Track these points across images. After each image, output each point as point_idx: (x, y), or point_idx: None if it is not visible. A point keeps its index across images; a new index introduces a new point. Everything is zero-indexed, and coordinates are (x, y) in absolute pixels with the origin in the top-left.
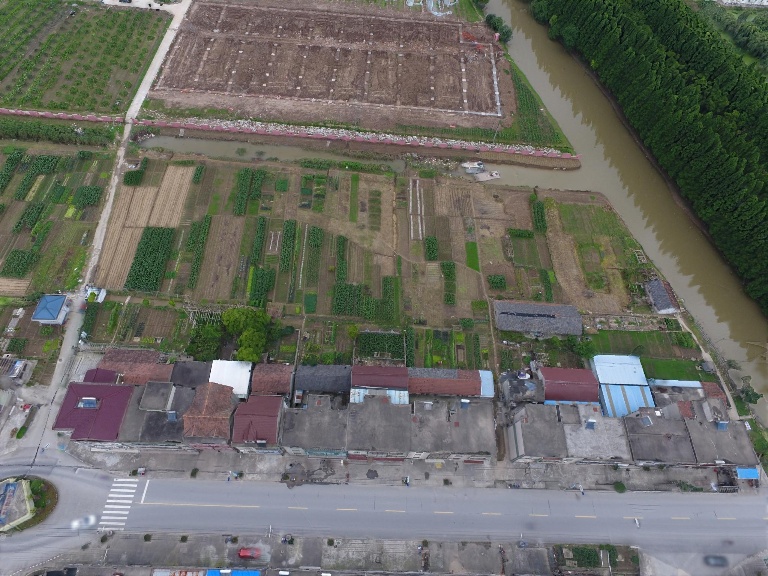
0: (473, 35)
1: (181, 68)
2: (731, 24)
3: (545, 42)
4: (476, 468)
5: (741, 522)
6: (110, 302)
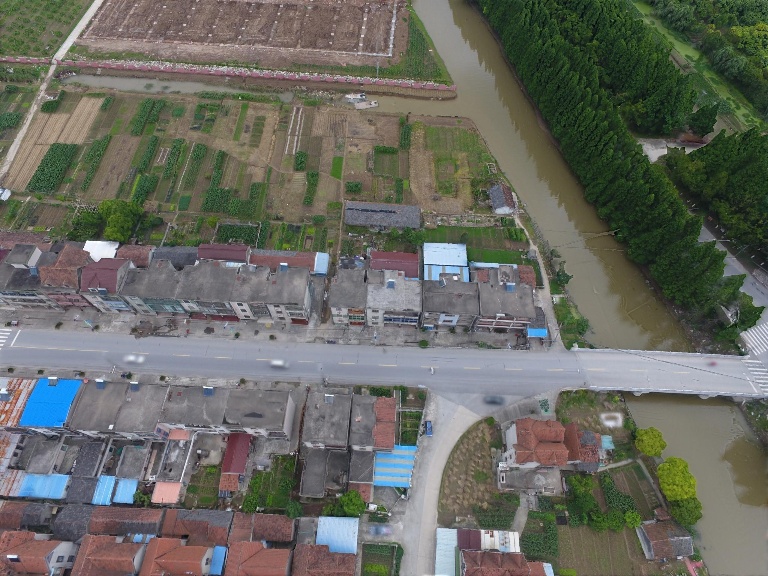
0: None
1: (109, 20)
2: None
3: None
4: (301, 328)
5: (526, 372)
6: (12, 200)
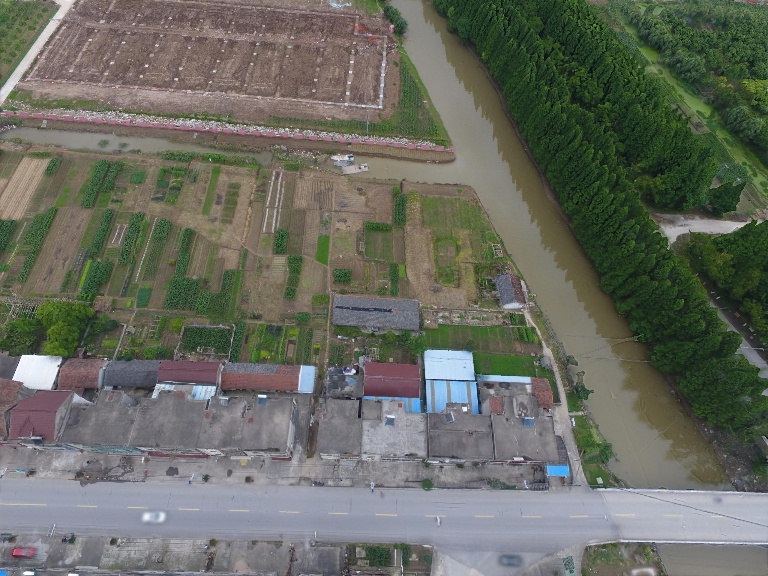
0: (368, 27)
1: (57, 59)
2: (636, 17)
3: (445, 34)
4: (283, 465)
5: (546, 520)
6: None
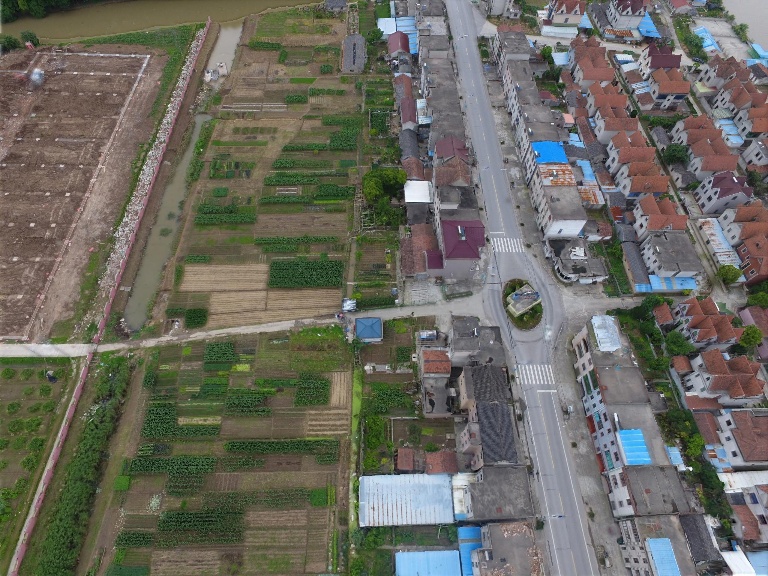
0: (19, 62)
1: None
2: None
3: (41, 25)
4: None
5: (458, 5)
6: None
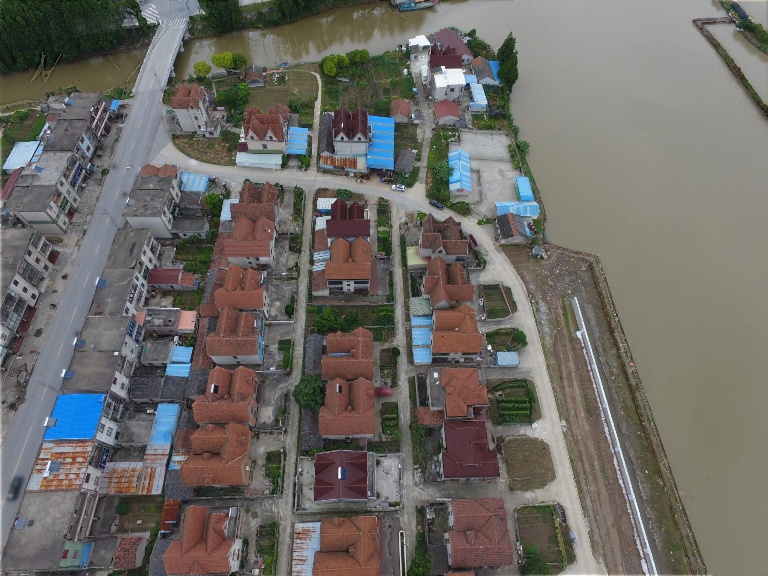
0: None
1: None
2: None
3: None
4: (62, 257)
5: (144, 118)
6: None
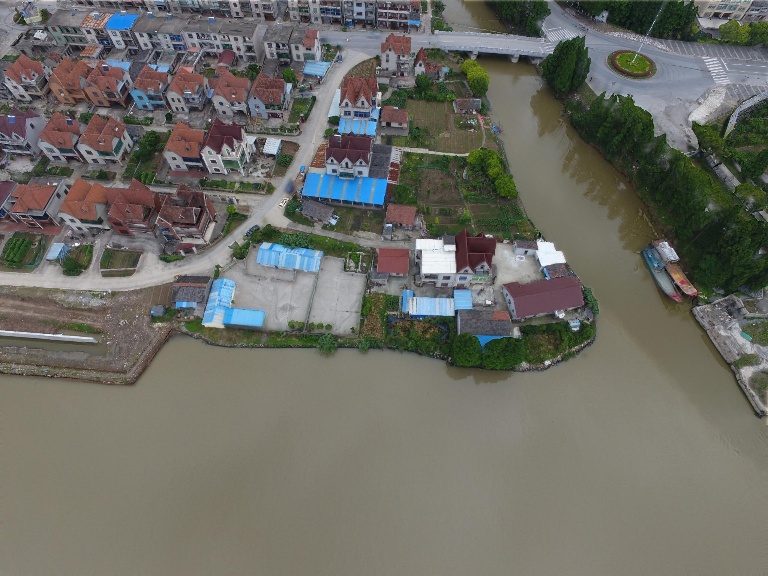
0: None
1: None
2: None
3: None
4: (270, 22)
5: None
6: None
